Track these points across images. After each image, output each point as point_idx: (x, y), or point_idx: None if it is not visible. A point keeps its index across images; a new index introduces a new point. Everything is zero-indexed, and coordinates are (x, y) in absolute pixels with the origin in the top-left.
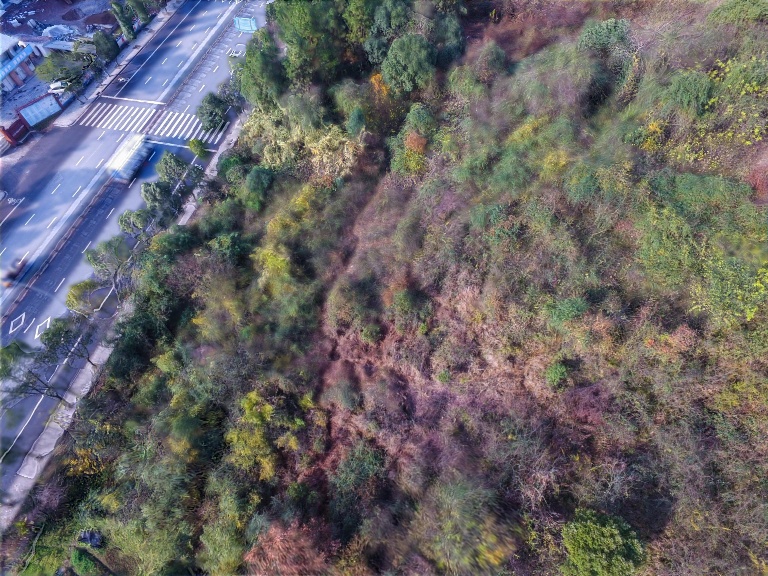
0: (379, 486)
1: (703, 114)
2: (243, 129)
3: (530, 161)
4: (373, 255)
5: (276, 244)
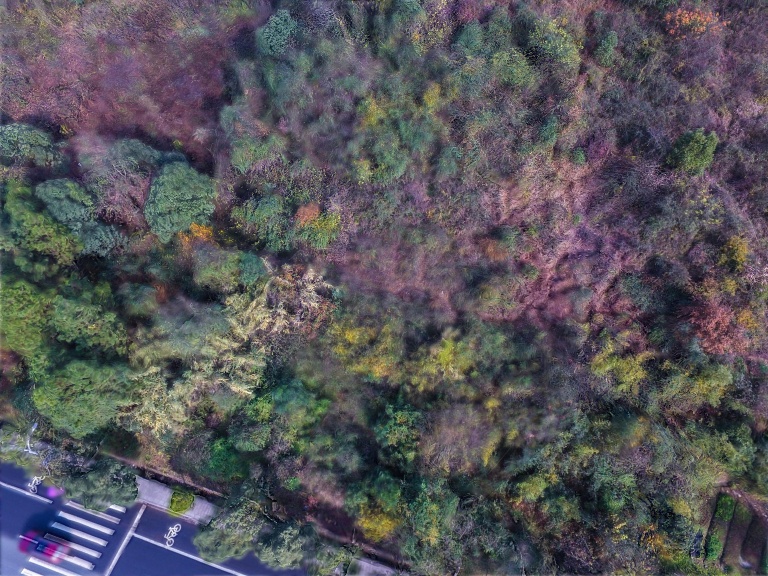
0: (648, 275)
1: (422, 8)
2: (170, 427)
3: (418, 112)
4: (437, 270)
5: (411, 360)
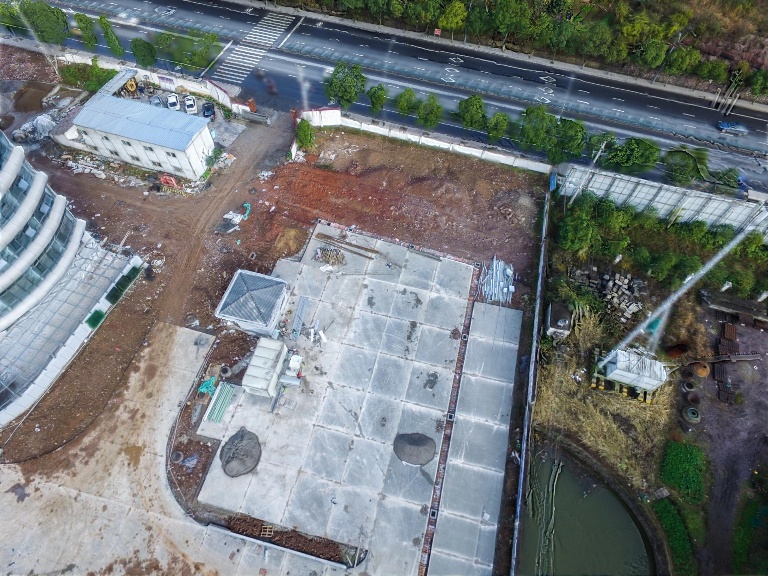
0: None
1: None
2: None
3: None
4: None
5: None
